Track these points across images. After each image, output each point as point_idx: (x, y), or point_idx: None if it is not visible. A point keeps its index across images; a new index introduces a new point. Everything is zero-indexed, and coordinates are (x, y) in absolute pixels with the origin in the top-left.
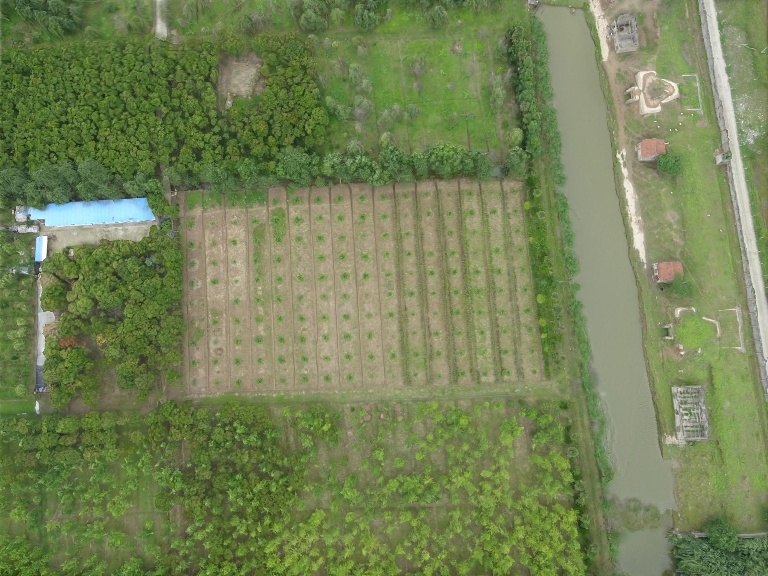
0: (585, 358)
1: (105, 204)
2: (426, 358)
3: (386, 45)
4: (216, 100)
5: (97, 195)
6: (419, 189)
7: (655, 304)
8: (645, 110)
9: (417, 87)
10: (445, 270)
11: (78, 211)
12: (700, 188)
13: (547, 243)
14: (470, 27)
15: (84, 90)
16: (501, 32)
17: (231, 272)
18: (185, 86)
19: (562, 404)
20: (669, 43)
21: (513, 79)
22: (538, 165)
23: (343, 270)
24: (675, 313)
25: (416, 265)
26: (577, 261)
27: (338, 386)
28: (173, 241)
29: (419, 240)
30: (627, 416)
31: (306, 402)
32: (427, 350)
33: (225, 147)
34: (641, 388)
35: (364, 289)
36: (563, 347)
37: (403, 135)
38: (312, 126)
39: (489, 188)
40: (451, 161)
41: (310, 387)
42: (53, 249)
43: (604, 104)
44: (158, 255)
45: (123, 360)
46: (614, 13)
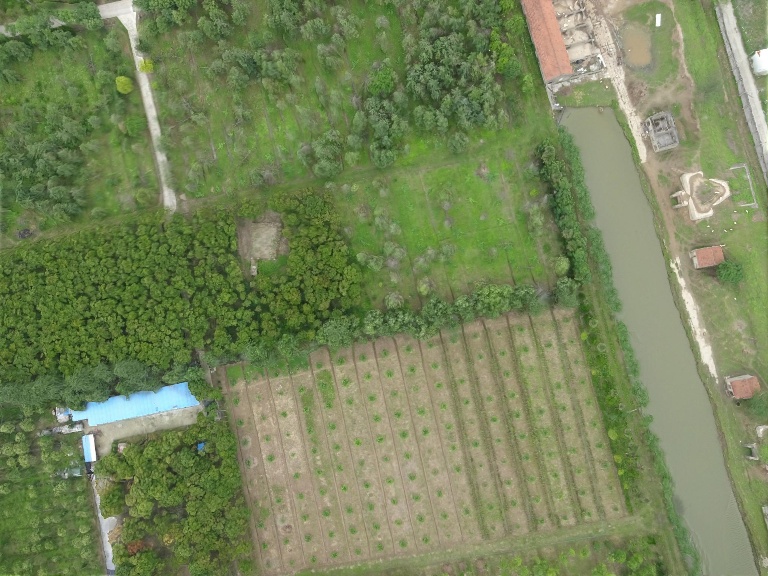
0: (669, 494)
1: (146, 395)
2: (501, 509)
3: (408, 179)
4: (240, 268)
5: (136, 389)
6: (466, 330)
7: (733, 421)
8: (696, 217)
9: (449, 224)
10: (507, 414)
11: (120, 406)
12: (766, 291)
13: (610, 371)
14: (494, 146)
15: (103, 281)
16: (528, 147)
17: (286, 445)
18: (207, 262)
19: (650, 540)
20: (711, 134)
21: (549, 201)
22: (588, 287)
23: (401, 427)
24: (757, 432)
25: (476, 412)
26: (646, 392)
27: (415, 549)
28: (222, 426)
29: (475, 385)
30: (718, 539)
31: (385, 570)
32: (501, 500)
33: (259, 321)
34: (729, 509)
35: (426, 445)
36: (642, 479)
37: (441, 275)
38: (346, 288)
39: (540, 319)
40: (499, 306)
41: (386, 554)
42: (101, 445)
43: (649, 209)
44: (210, 444)
45: (194, 558)
46: (646, 108)
